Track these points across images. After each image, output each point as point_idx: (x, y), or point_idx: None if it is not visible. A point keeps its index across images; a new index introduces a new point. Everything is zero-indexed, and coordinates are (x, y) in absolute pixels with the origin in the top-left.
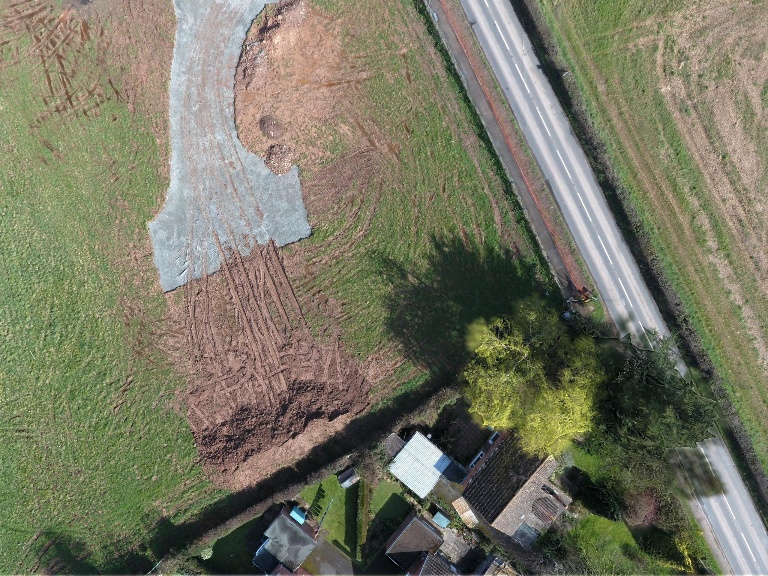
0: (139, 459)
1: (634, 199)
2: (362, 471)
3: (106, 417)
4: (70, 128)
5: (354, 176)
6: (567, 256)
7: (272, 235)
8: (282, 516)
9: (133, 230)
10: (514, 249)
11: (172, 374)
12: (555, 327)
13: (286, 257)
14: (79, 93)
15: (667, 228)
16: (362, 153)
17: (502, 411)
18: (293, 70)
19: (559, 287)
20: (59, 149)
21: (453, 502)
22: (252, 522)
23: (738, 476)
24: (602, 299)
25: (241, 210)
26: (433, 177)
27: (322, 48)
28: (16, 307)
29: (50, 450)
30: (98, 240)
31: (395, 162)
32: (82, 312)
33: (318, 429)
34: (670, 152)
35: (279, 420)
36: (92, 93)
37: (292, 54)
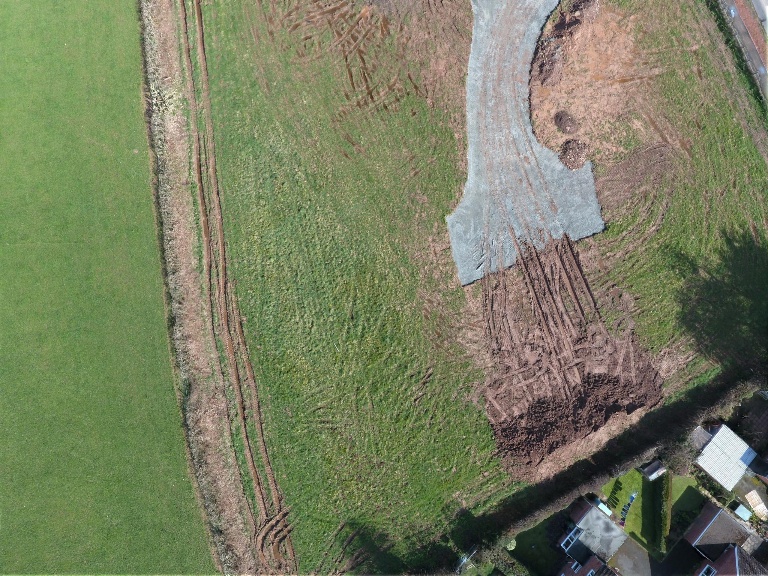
0: (439, 451)
1: None
2: (674, 463)
3: (407, 409)
4: (371, 122)
5: (647, 171)
6: None
7: (566, 229)
8: (595, 508)
9: (432, 224)
10: None
11: (471, 367)
12: None
13: (581, 251)
14: (380, 88)
15: None
16: (655, 149)
17: None
18: (587, 66)
19: None
20: (361, 143)
21: (746, 495)
22: None
23: None
24: None
25: (536, 205)
26: (724, 173)
27: (615, 44)
28: (320, 299)
29: (354, 441)
30: (398, 234)
31: (687, 158)
32: (384, 305)
33: (617, 422)
34: None
35: (578, 413)
36: (392, 88)
37: (587, 50)
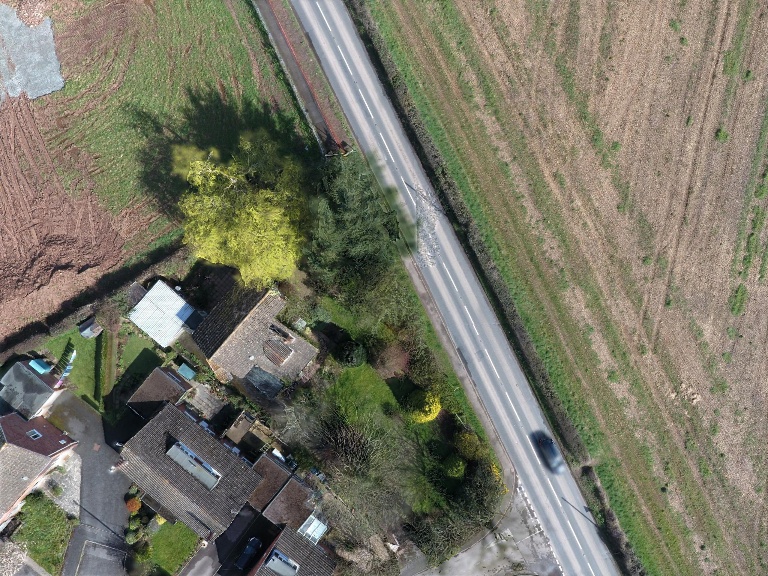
0: None
1: (397, 53)
2: (99, 317)
3: None
4: None
5: (108, 27)
6: (326, 109)
7: (24, 87)
8: (17, 363)
9: None
10: (272, 103)
11: None
12: (269, 155)
13: (37, 109)
14: None
15: (432, 83)
16: (116, 4)
17: (205, 235)
18: None
19: (317, 140)
20: None
21: None
22: None
23: (503, 335)
24: (363, 154)
25: None
26: (189, 29)
27: None
28: None
29: None
30: None
31: (150, 14)
32: None
33: (66, 282)
34: (436, 6)
35: (26, 273)
36: None
37: None
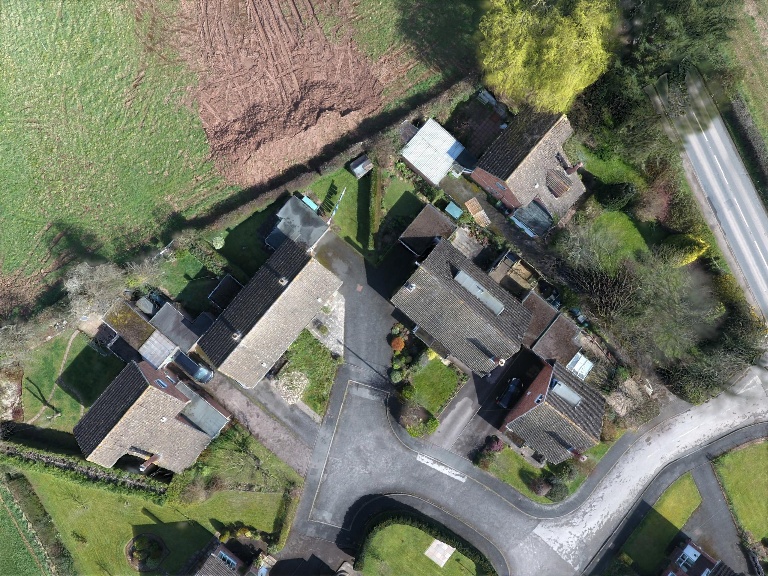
0: (151, 154)
1: None
2: (375, 152)
3: (118, 111)
4: None
5: None
6: None
7: None
8: (295, 196)
9: None
10: None
11: (184, 70)
12: None
13: None
14: None
15: None
16: None
17: (518, 49)
18: None
19: None
20: None
21: (466, 202)
22: (264, 216)
23: (751, 185)
24: None
25: None
26: None
27: None
28: None
29: (61, 142)
30: None
31: None
32: (94, 6)
33: (330, 124)
34: None
35: (291, 115)
36: None
37: None
